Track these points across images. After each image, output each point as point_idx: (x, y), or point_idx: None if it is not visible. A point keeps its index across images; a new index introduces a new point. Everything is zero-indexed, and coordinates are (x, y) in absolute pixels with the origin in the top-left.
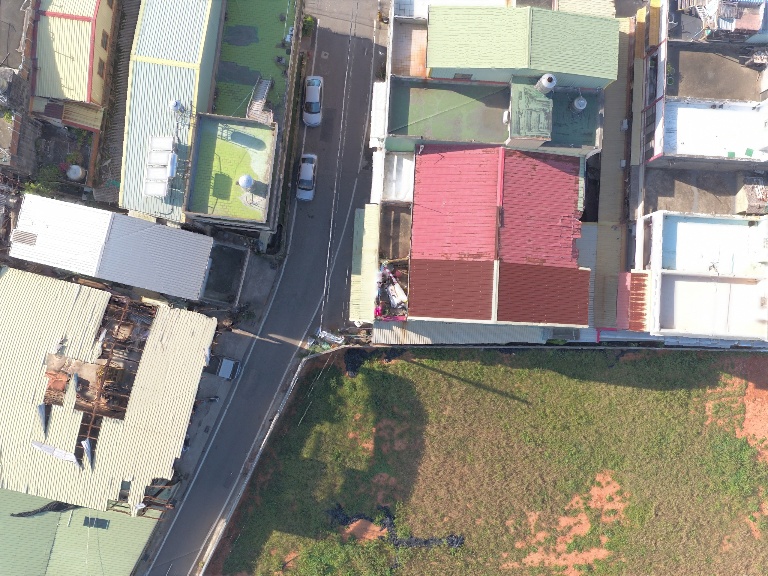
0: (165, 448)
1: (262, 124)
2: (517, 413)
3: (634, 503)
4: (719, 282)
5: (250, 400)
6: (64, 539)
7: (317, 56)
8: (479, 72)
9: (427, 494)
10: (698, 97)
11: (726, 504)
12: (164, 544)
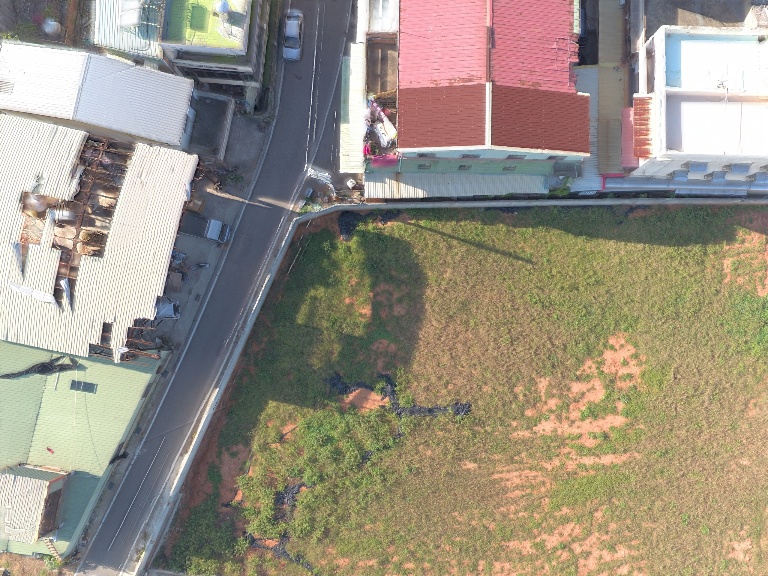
0: (147, 286)
1: None
2: (522, 274)
3: (651, 366)
4: (729, 101)
5: (241, 266)
6: (51, 403)
7: None
8: None
9: (429, 360)
10: None
11: (750, 365)
12: (156, 417)
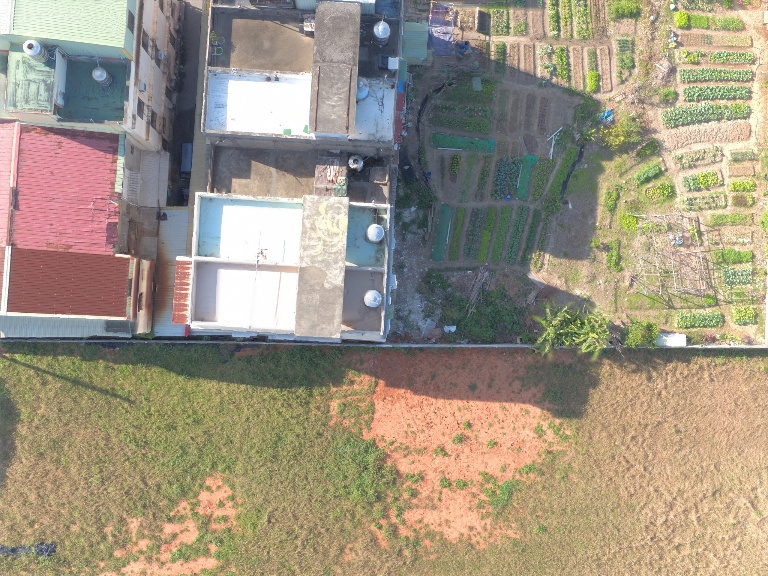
0: None
1: None
2: (118, 412)
3: (245, 509)
4: (268, 271)
5: None
6: None
7: None
8: None
9: (16, 499)
10: None
11: (348, 510)
12: None
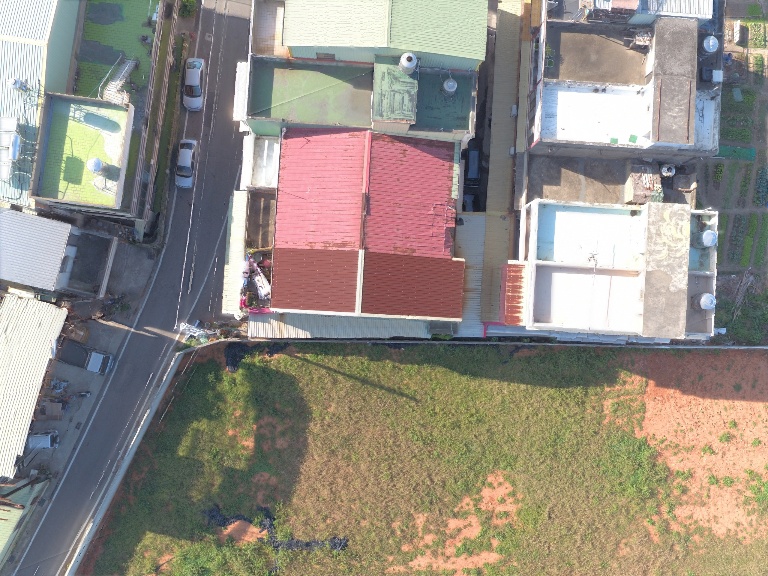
0: (6, 445)
1: (117, 105)
2: (405, 411)
3: (527, 505)
4: (599, 274)
5: (124, 395)
6: None
7: (201, 38)
8: (340, 51)
9: (309, 494)
10: (579, 80)
11: (623, 506)
12: (31, 545)
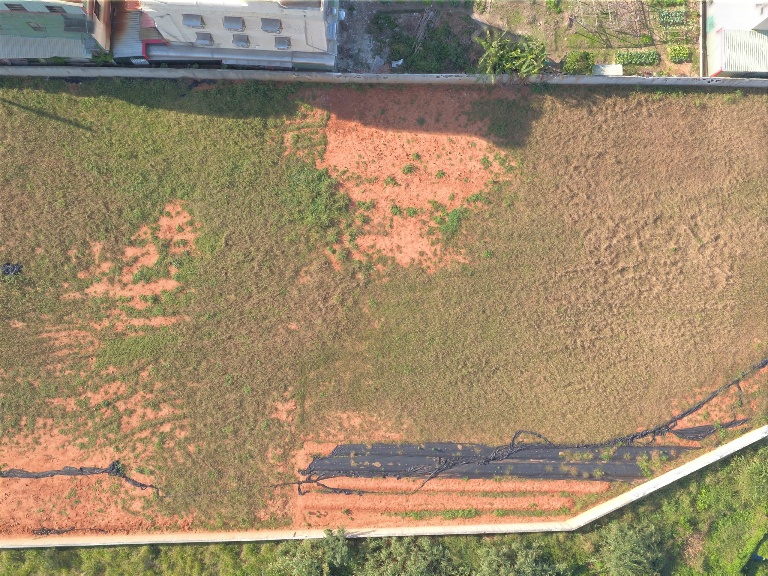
0: None
1: None
2: (80, 141)
3: (203, 232)
4: None
5: None
6: None
7: None
8: None
9: None
10: None
11: (303, 234)
12: None
